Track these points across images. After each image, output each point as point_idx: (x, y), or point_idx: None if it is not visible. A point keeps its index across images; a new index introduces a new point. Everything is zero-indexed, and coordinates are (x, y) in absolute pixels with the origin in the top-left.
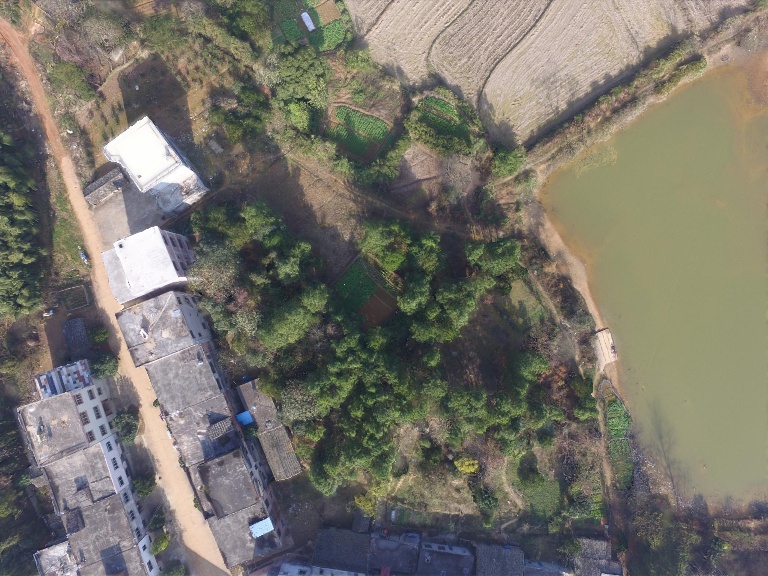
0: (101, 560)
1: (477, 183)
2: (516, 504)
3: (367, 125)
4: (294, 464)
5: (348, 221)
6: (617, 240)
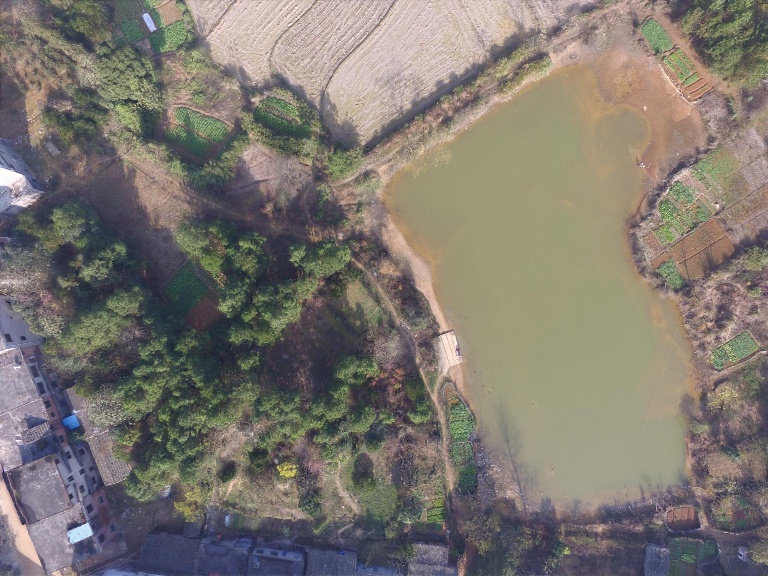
0: None
1: None
2: (351, 509)
3: (207, 126)
4: (123, 469)
5: (182, 223)
6: (463, 241)
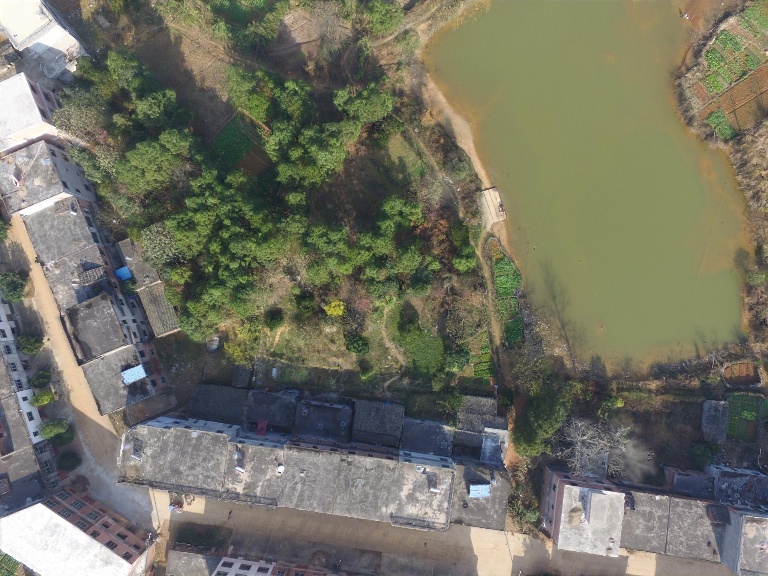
0: None
1: None
2: (398, 360)
3: None
4: (173, 320)
5: (226, 83)
6: (503, 99)
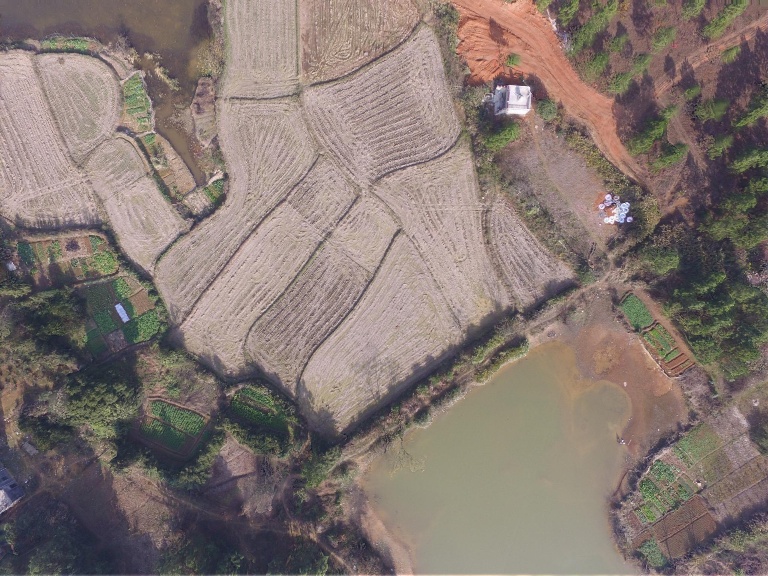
0: None
1: (295, 476)
2: None
3: (183, 420)
4: None
5: (160, 527)
6: (442, 524)
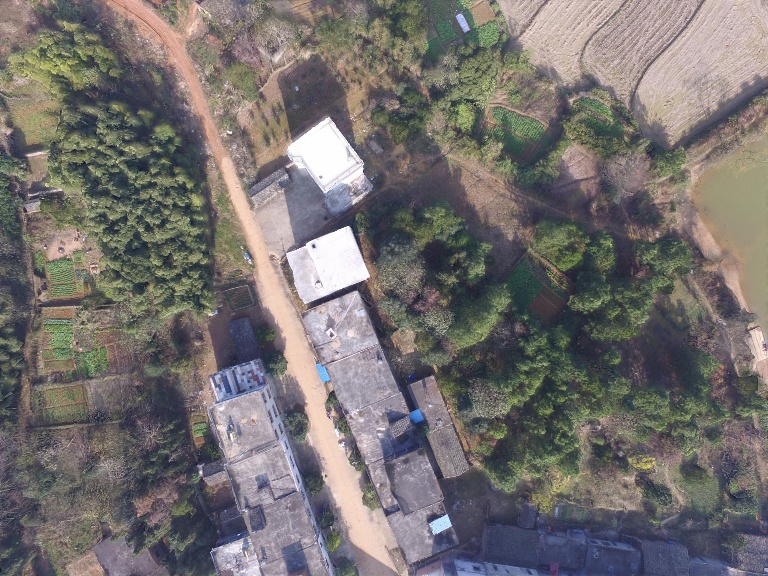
0: (282, 557)
1: (632, 183)
2: (677, 500)
3: (524, 126)
4: (463, 461)
5: (511, 221)
6: (767, 239)
